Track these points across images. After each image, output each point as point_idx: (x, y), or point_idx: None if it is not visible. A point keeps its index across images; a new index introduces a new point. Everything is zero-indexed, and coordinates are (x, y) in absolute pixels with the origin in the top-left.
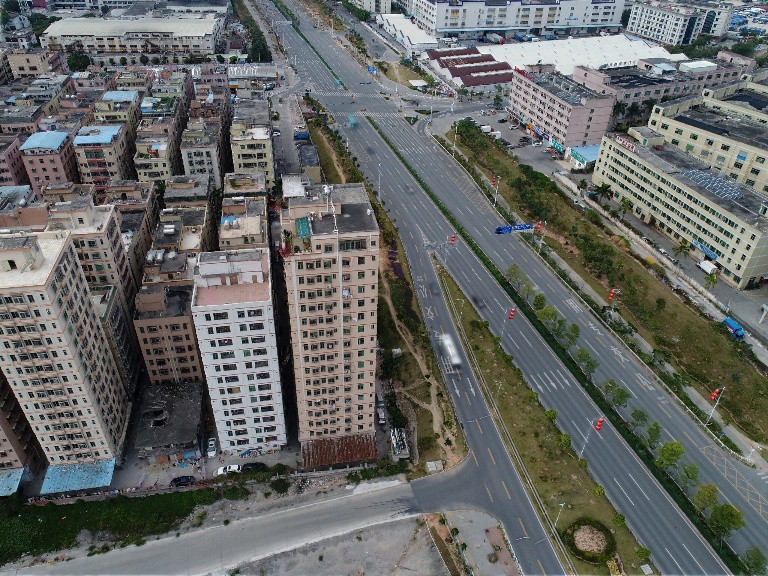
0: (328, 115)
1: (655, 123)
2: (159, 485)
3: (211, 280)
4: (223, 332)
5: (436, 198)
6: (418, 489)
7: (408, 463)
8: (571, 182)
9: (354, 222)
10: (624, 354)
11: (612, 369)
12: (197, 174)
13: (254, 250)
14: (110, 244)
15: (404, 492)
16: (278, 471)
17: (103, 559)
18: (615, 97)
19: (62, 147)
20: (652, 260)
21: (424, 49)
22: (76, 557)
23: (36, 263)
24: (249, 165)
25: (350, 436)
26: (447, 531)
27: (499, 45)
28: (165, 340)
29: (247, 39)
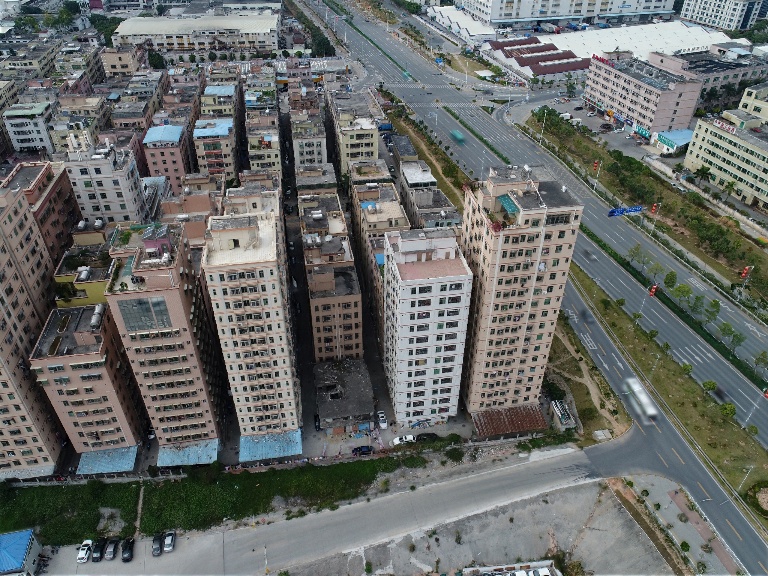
0: (405, 106)
1: (746, 106)
2: (345, 454)
3: (409, 257)
4: (423, 305)
5: None
6: (593, 456)
7: (573, 433)
8: (665, 166)
9: (554, 198)
10: (759, 329)
11: (751, 343)
12: None
13: (435, 229)
14: (280, 227)
15: (580, 459)
16: (454, 440)
17: (302, 522)
18: (703, 81)
19: (179, 140)
20: (765, 239)
21: (482, 40)
22: (275, 521)
23: (258, 241)
24: (356, 154)
25: (516, 407)
26: (632, 494)
27: (559, 34)
28: (335, 318)
29: (307, 34)
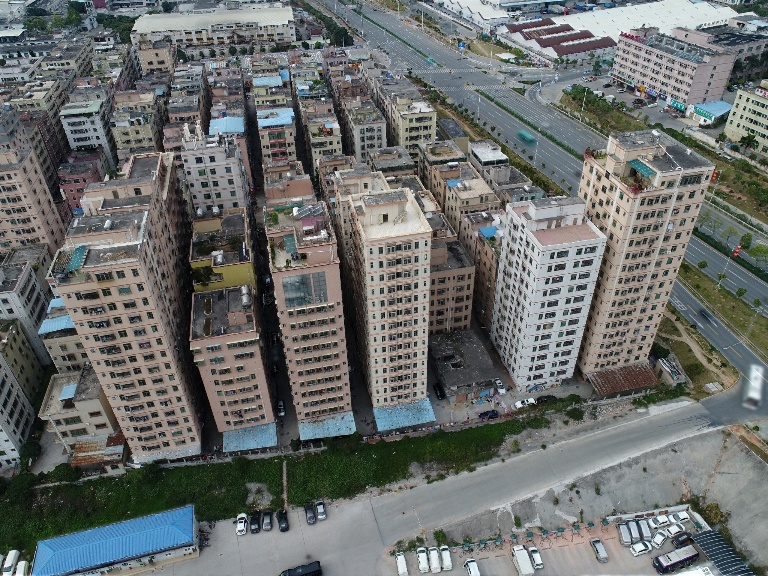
0: (437, 91)
1: None
2: (474, 419)
3: (540, 224)
4: (559, 270)
5: None
6: (710, 407)
7: (683, 387)
8: (707, 136)
9: (682, 161)
10: None
11: None
12: None
13: (553, 198)
14: None
15: (698, 410)
16: (576, 400)
17: (444, 485)
18: (736, 53)
19: None
20: None
21: (496, 24)
22: (417, 485)
23: None
24: (414, 138)
25: (628, 367)
26: (757, 438)
27: (571, 15)
28: (449, 291)
29: (321, 25)
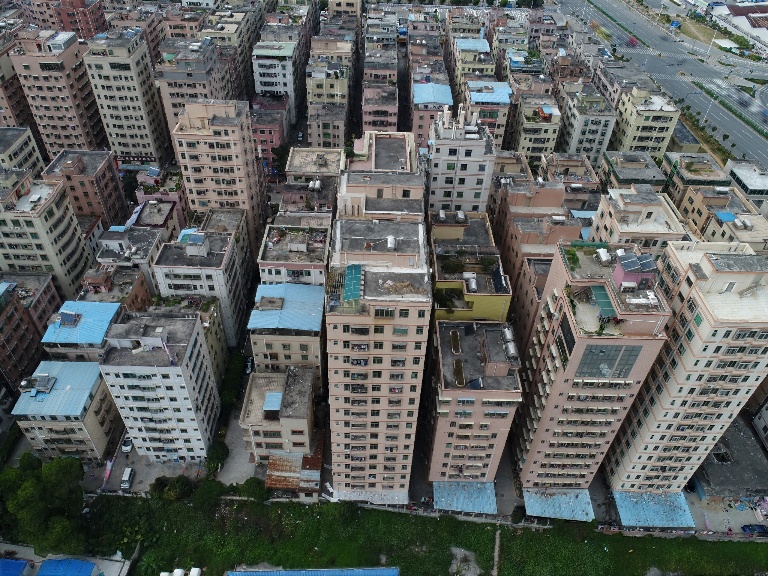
0: None
1: None
2: (740, 533)
3: None
4: None
5: None
6: None
7: None
8: None
9: None
10: None
11: None
12: (584, 144)
13: None
14: None
15: None
16: None
17: None
18: None
19: None
20: None
21: (709, 1)
22: None
23: None
24: (644, 139)
25: None
26: None
27: None
28: None
29: None
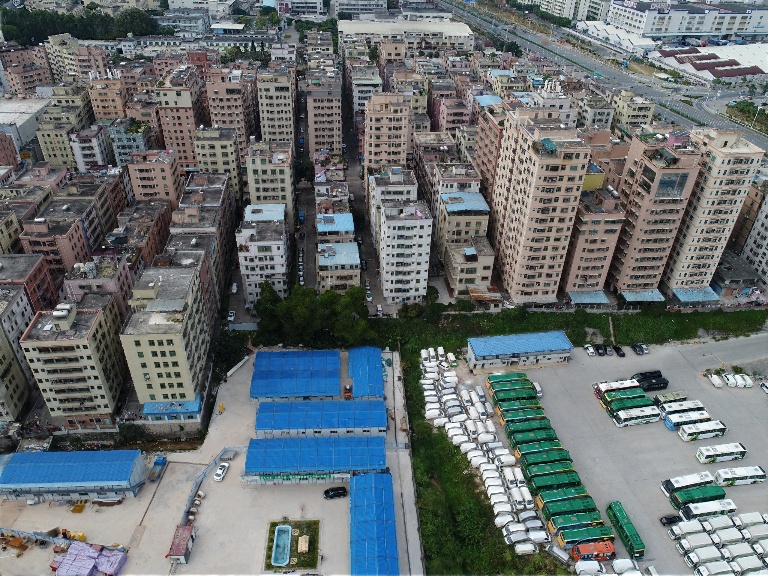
0: None
1: None
2: (745, 303)
3: None
4: None
5: None
6: None
7: None
8: None
9: None
10: None
11: None
12: None
13: None
14: None
15: None
16: None
17: (728, 343)
18: None
19: None
20: None
21: None
22: (708, 342)
23: None
24: None
25: None
26: None
27: (714, 46)
28: None
29: None
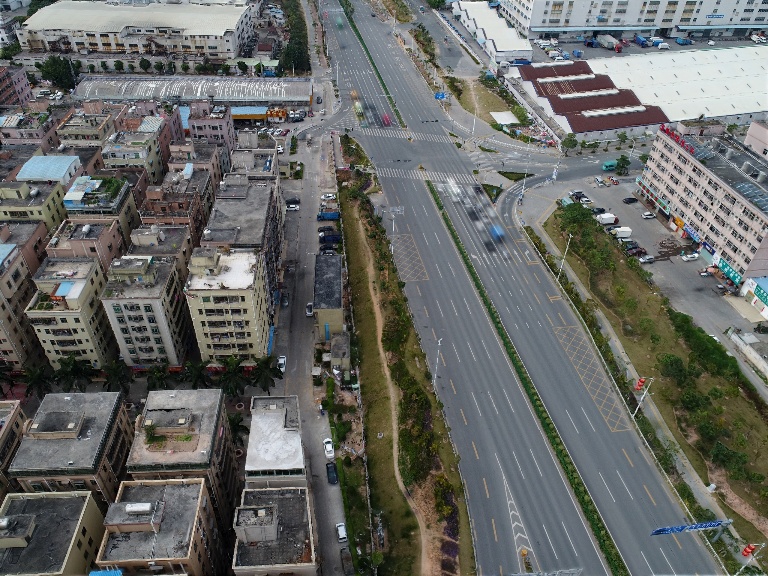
0: (372, 175)
1: None
2: None
3: None
4: None
5: (531, 389)
6: None
7: None
8: (766, 364)
9: None
10: None
11: None
12: (133, 333)
13: None
14: None
15: None
16: None
17: None
18: None
19: None
20: None
21: (513, 58)
22: None
23: None
24: (218, 323)
25: None
26: None
27: (618, 59)
28: None
29: (283, 35)
